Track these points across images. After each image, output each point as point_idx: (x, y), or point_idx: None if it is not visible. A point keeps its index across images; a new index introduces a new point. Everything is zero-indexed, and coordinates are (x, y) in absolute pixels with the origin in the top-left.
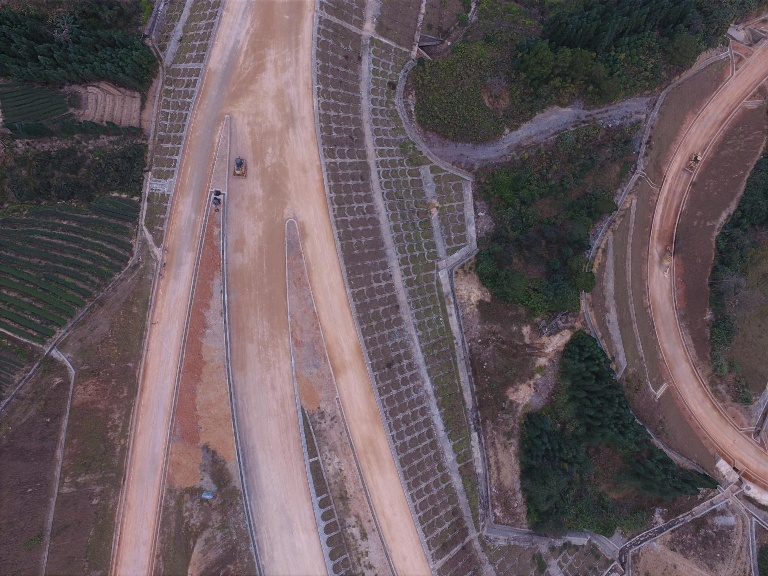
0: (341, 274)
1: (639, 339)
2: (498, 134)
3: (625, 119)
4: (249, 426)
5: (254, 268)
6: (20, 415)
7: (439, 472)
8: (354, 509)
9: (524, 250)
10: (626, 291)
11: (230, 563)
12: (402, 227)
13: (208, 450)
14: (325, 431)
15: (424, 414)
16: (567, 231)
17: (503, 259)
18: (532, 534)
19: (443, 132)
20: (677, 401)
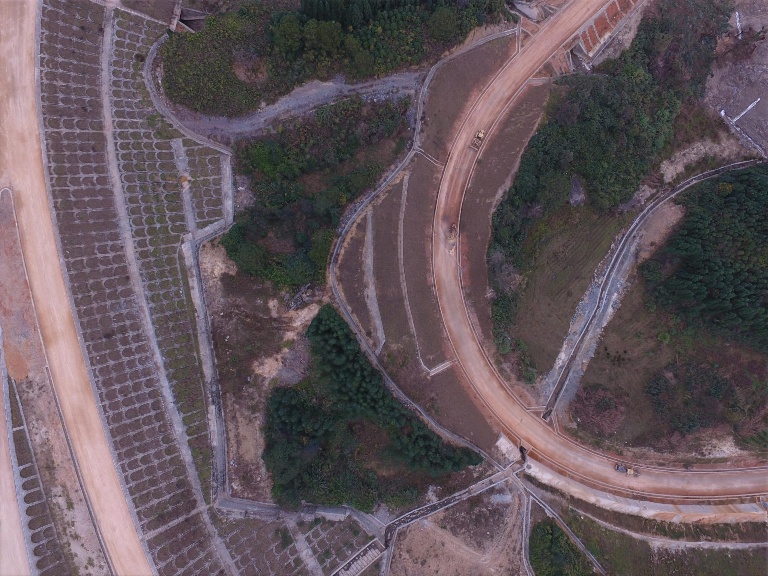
0: (55, 243)
1: (411, 316)
2: (252, 107)
3: (390, 94)
4: None
5: None
6: None
7: (164, 444)
8: (61, 479)
9: None
10: (396, 267)
11: None
12: (141, 199)
13: None
14: (33, 400)
15: (151, 386)
16: None
17: (249, 232)
18: (280, 509)
19: (192, 105)
20: (461, 379)
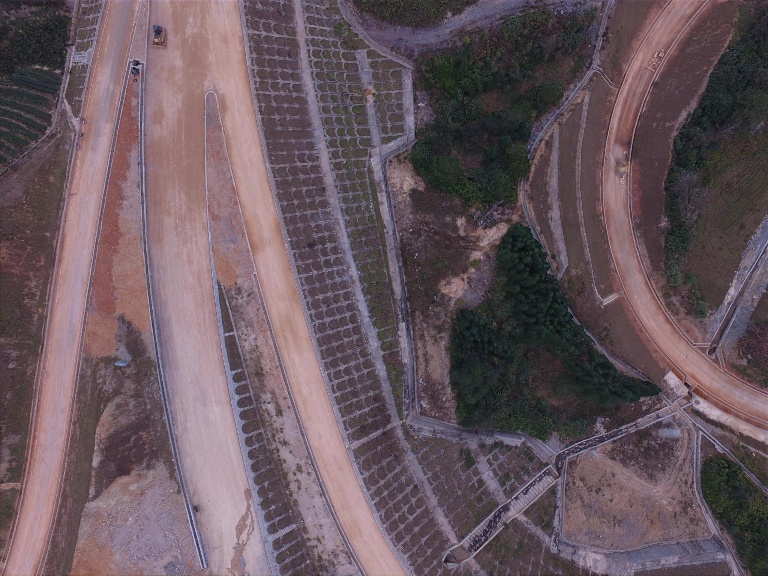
0: (261, 149)
1: (586, 242)
2: (439, 17)
3: (578, 5)
4: (165, 299)
5: (173, 141)
6: None
7: (361, 357)
8: (269, 386)
9: (465, 143)
10: (574, 191)
11: (143, 430)
12: (332, 109)
13: (123, 321)
14: (241, 307)
15: (348, 299)
16: (507, 119)
17: (439, 147)
18: (462, 430)
19: (380, 13)
20: (628, 312)
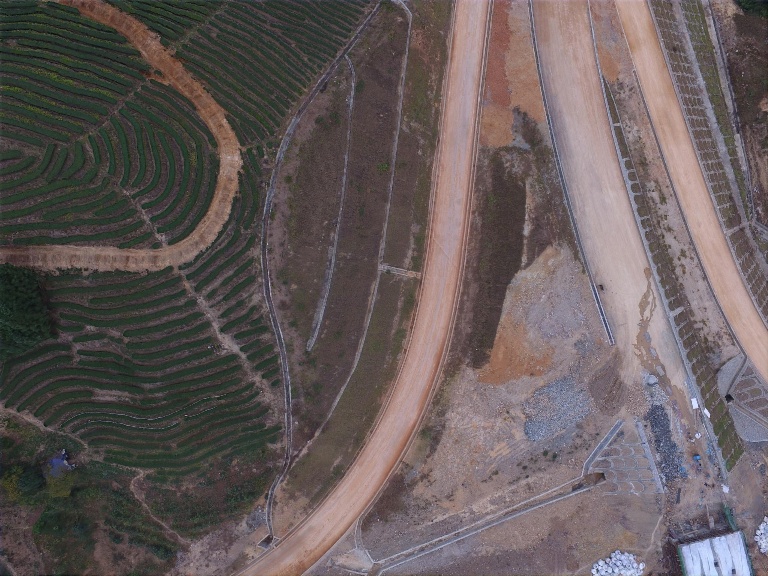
0: None
1: None
2: None
3: None
4: (555, 92)
5: None
6: (375, 39)
7: (716, 158)
8: (653, 175)
9: None
10: None
11: (548, 212)
12: None
13: (519, 112)
14: (624, 101)
15: (699, 105)
16: None
17: None
18: None
19: None
20: None
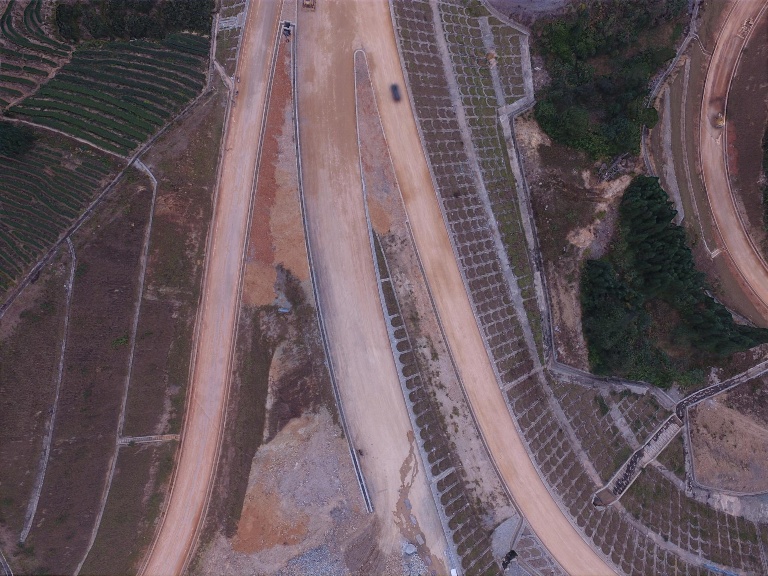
0: (409, 103)
1: (694, 198)
2: None
3: None
4: (322, 247)
5: (324, 97)
6: (108, 215)
7: (505, 304)
8: (425, 330)
9: (581, 103)
10: (681, 149)
11: (306, 376)
12: (464, 70)
13: (282, 269)
14: (396, 254)
15: (489, 248)
16: (626, 77)
17: (563, 105)
18: (593, 378)
19: None
20: (730, 267)
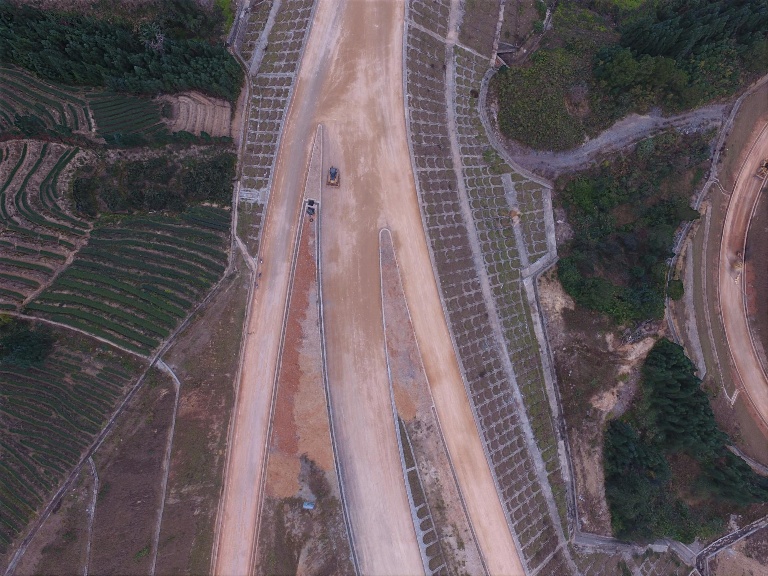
0: (435, 283)
1: (714, 346)
2: (579, 142)
3: (702, 126)
4: (346, 436)
5: (349, 278)
6: (130, 427)
7: (530, 481)
8: (451, 518)
9: (603, 257)
10: (702, 298)
11: (331, 573)
12: (488, 235)
13: (307, 460)
14: (421, 441)
15: (514, 423)
16: (650, 239)
17: (586, 267)
18: (615, 542)
19: (525, 140)
20: (748, 407)
